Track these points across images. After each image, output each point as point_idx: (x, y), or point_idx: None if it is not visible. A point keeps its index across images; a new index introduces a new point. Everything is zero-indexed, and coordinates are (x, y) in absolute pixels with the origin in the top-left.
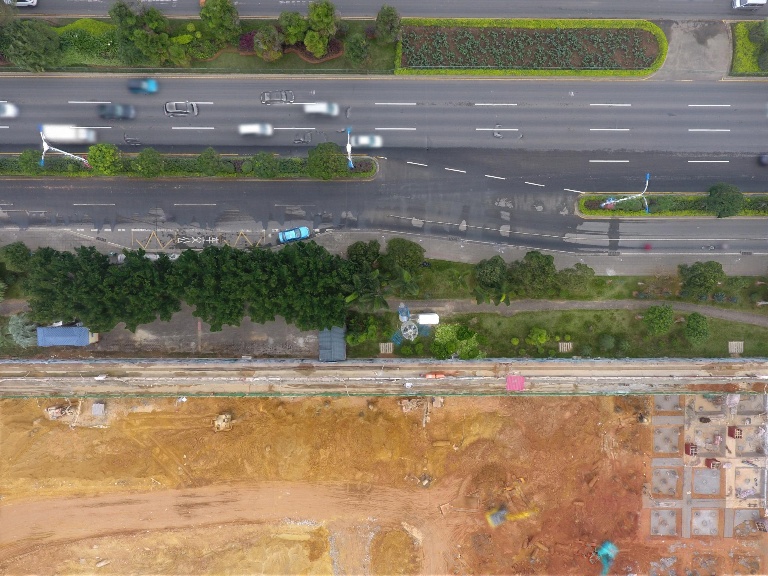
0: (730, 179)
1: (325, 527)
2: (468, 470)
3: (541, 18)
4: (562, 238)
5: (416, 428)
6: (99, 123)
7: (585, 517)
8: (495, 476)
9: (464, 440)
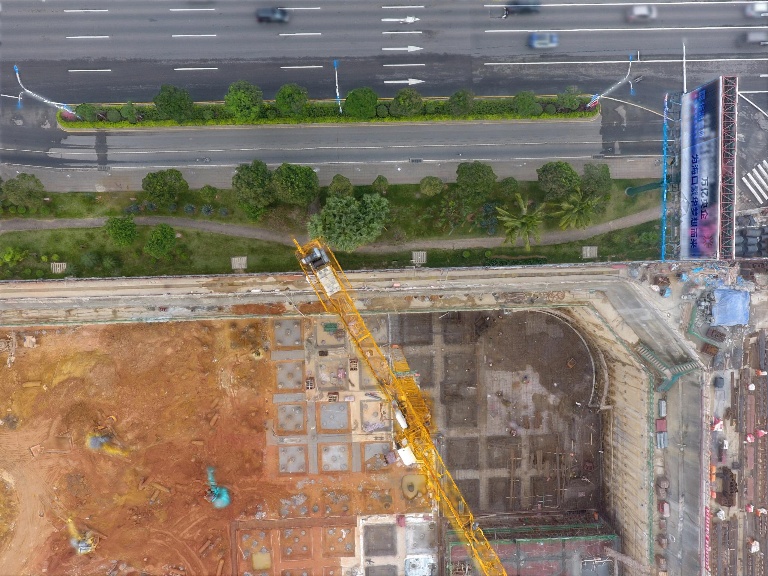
0: (220, 87)
1: None
2: (57, 410)
3: None
4: (45, 153)
5: (5, 369)
6: None
7: (207, 456)
8: (86, 415)
9: (53, 379)
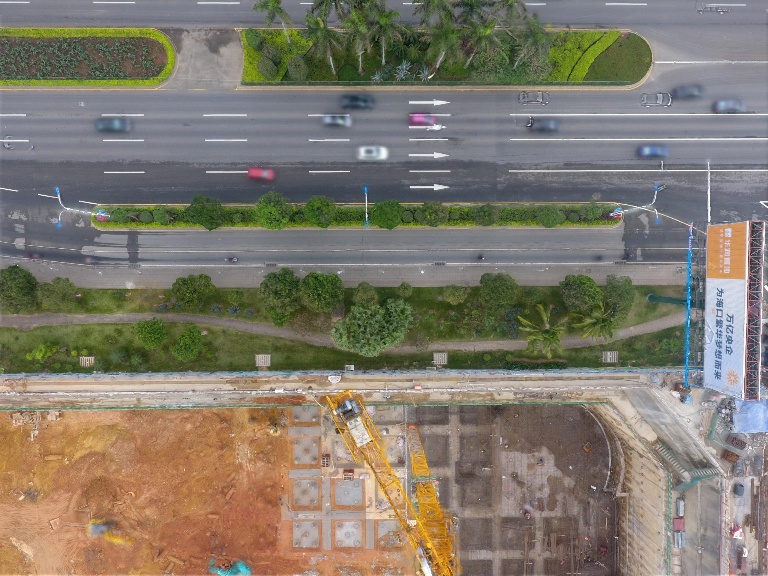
0: (250, 190)
1: None
2: (77, 484)
3: (45, 27)
4: (79, 251)
5: (28, 442)
6: None
7: (222, 530)
8: (105, 490)
9: (74, 454)
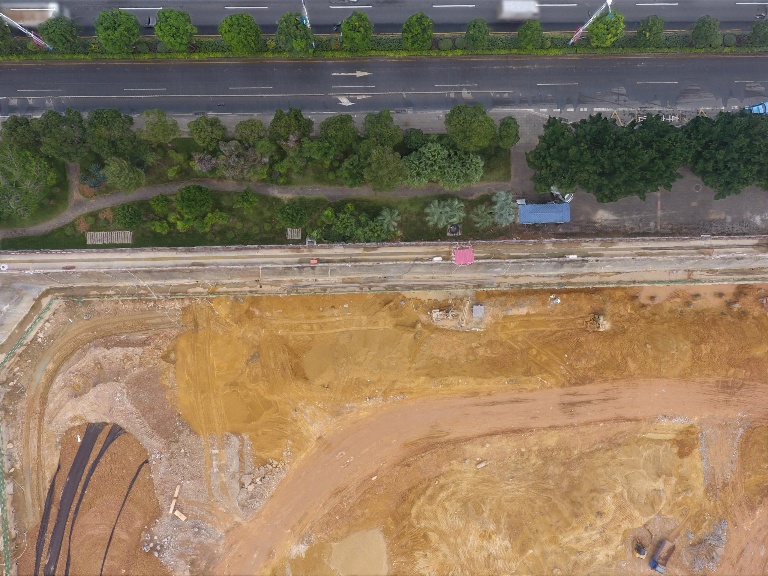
0: None
1: (697, 424)
2: None
3: None
4: None
5: None
6: (564, 0)
7: None
8: None
9: None
